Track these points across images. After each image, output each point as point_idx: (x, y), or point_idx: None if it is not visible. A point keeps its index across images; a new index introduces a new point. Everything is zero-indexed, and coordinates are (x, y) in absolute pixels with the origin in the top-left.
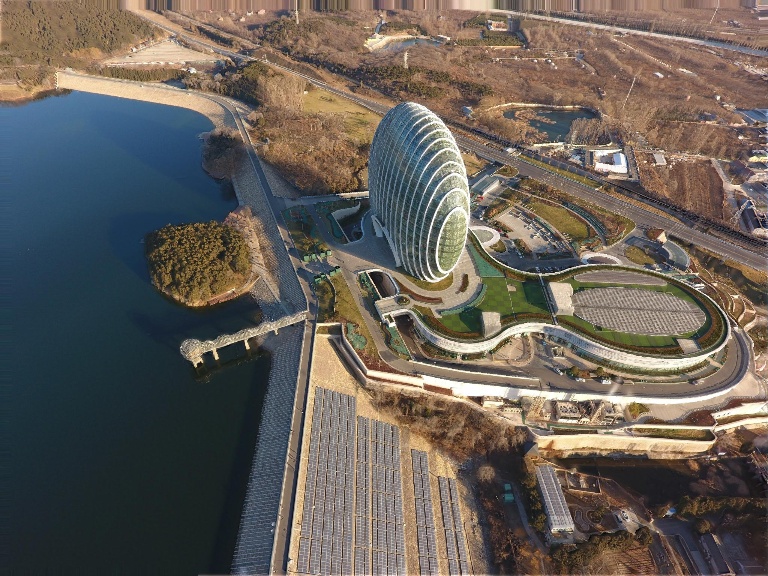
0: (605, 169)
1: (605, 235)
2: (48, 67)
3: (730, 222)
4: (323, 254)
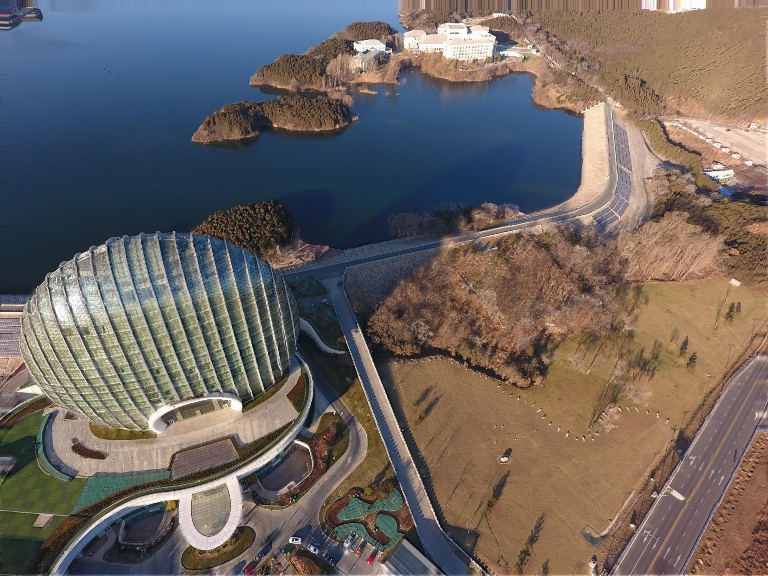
0: None
1: None
2: (600, 94)
3: None
4: None
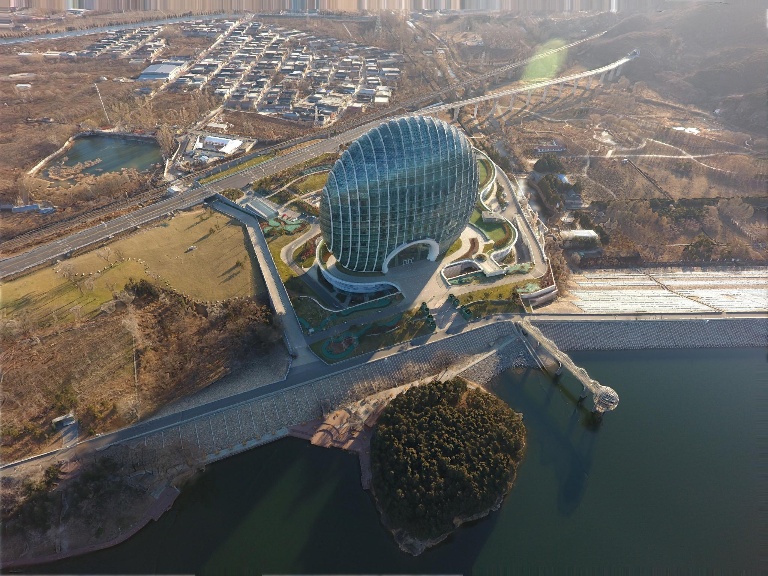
0: (233, 149)
1: None
2: None
3: (317, 125)
4: None
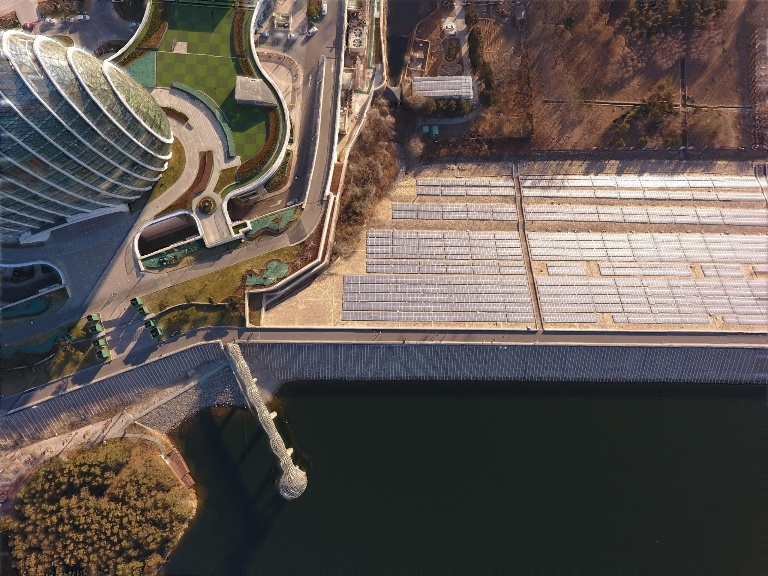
0: None
1: None
2: None
3: None
4: (97, 327)
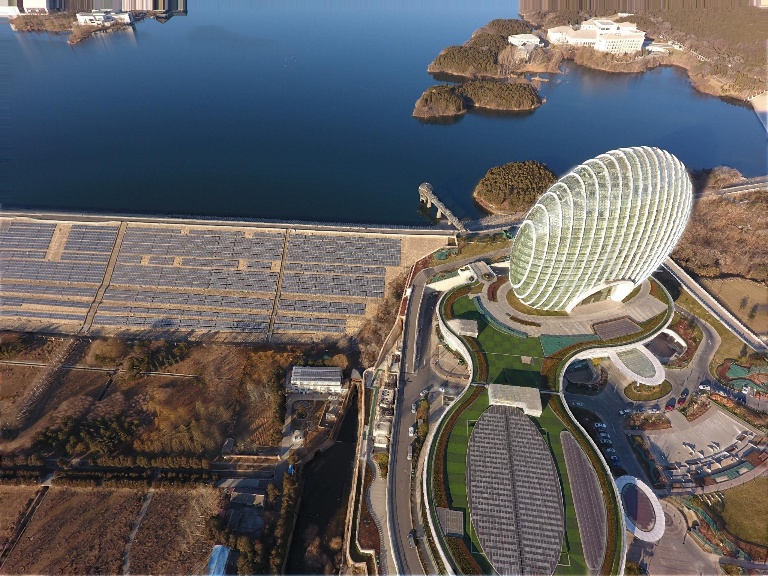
0: None
1: (757, 572)
2: (765, 84)
3: None
4: None
